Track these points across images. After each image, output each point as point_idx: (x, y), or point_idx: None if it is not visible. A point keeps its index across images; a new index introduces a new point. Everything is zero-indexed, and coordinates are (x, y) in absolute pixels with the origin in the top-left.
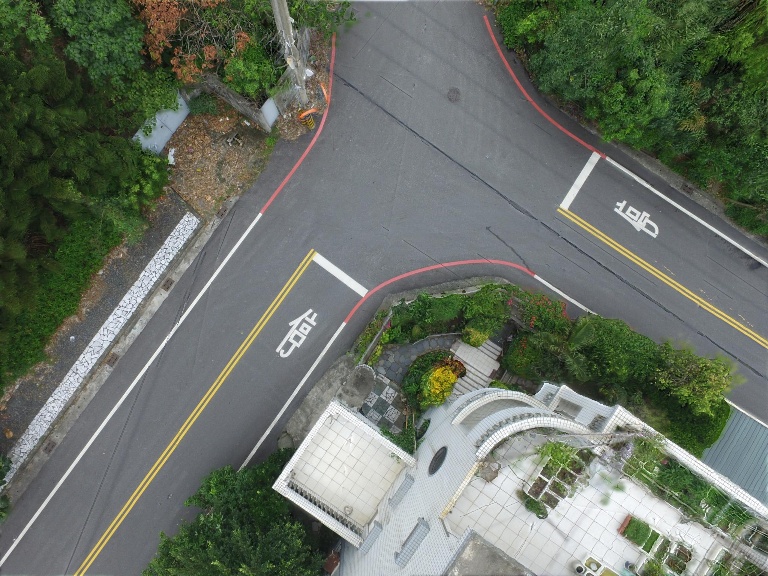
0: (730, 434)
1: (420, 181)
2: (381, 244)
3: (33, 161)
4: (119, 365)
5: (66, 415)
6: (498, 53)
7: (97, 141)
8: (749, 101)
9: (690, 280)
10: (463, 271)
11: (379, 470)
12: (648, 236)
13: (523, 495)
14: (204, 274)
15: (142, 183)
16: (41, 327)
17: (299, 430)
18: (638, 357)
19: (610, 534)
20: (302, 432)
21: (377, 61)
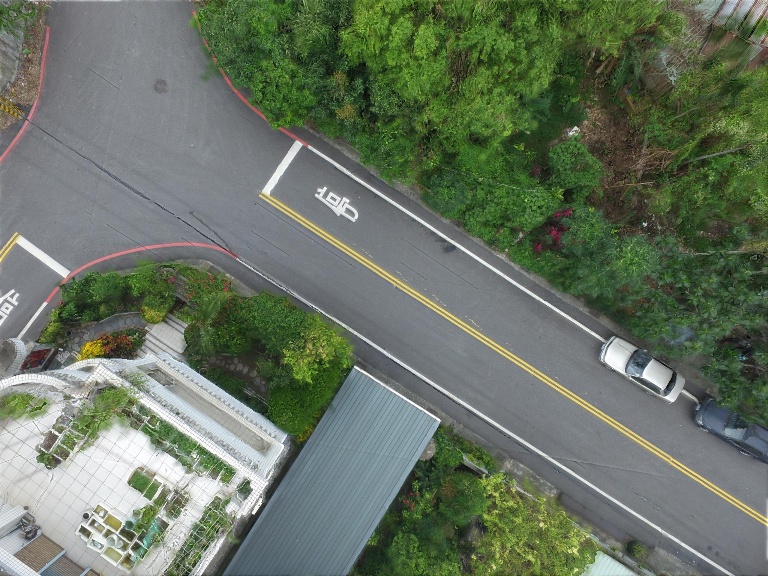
0: (364, 403)
1: (125, 168)
2: (84, 228)
3: None
4: None
5: None
6: (206, 47)
7: None
8: (387, 91)
9: (387, 262)
10: (167, 254)
11: None
12: (347, 221)
13: (39, 448)
14: None
15: None
16: None
17: None
18: (289, 332)
19: (124, 484)
20: None
21: (86, 54)
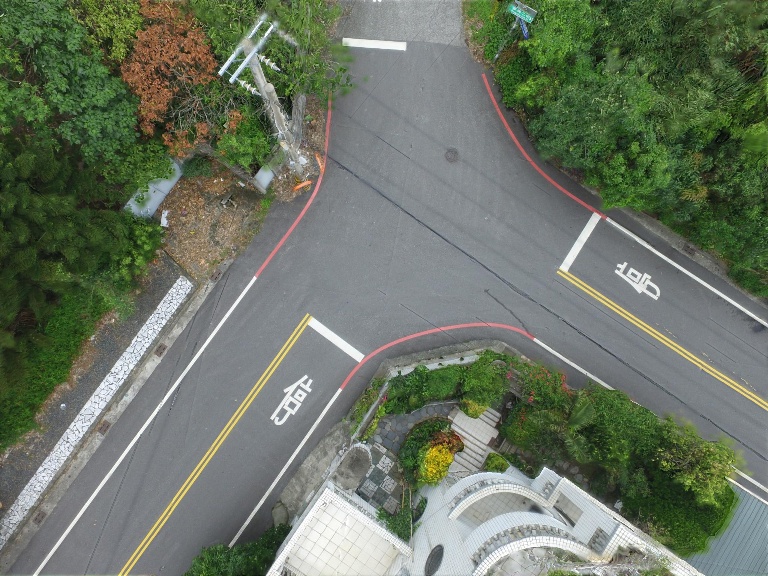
0: (734, 514)
1: (417, 243)
2: (378, 308)
3: (20, 249)
4: (111, 433)
5: (56, 485)
6: (497, 112)
7: (87, 219)
8: (752, 173)
9: (692, 343)
10: (461, 335)
11: (375, 554)
12: (649, 298)
13: None
14: (197, 339)
15: (134, 255)
16: (31, 397)
17: (294, 500)
18: (639, 433)
19: None
20: (297, 502)
21: (374, 121)
